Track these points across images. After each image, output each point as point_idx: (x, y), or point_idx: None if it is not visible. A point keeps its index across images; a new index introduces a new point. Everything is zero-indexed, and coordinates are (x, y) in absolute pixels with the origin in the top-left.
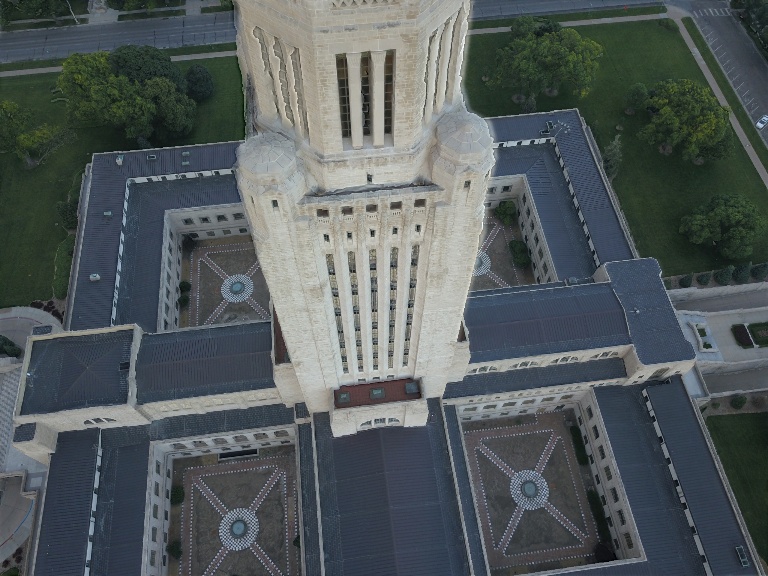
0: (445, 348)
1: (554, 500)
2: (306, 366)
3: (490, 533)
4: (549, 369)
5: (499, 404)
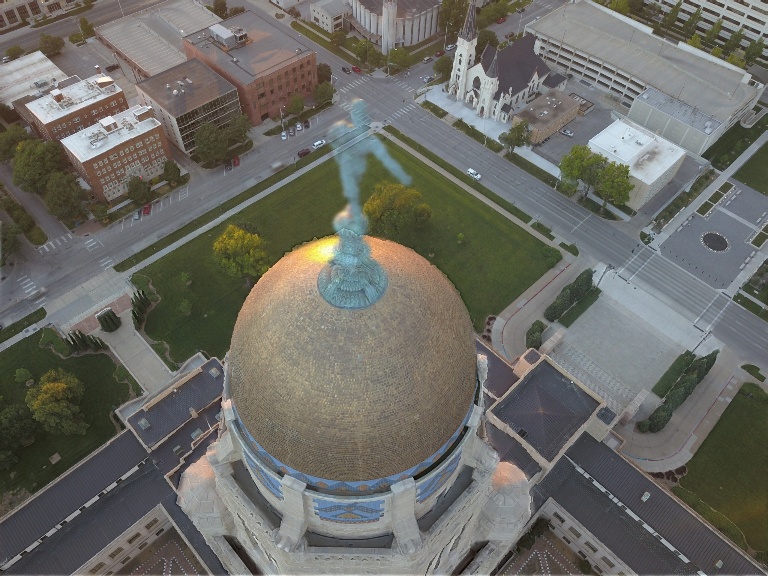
0: None
1: None
2: None
3: (183, 567)
4: None
5: None
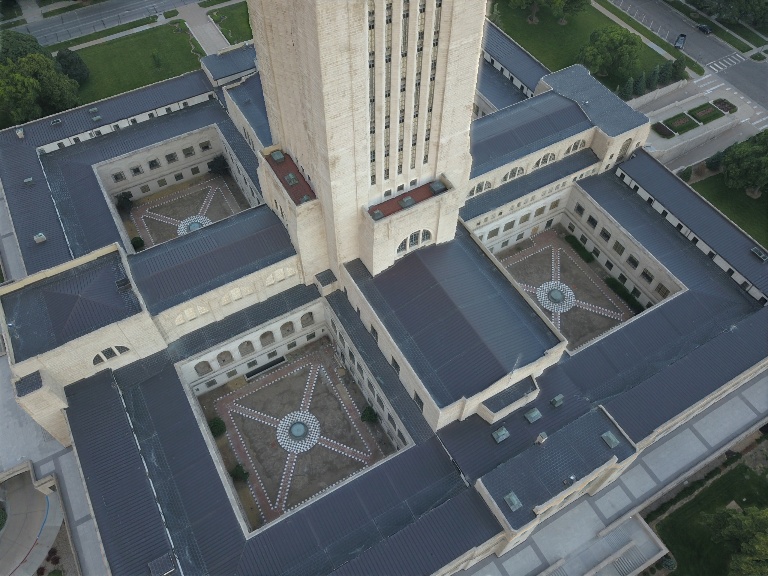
0: (463, 116)
1: (581, 297)
2: (341, 166)
3: None
4: (534, 174)
5: (501, 225)
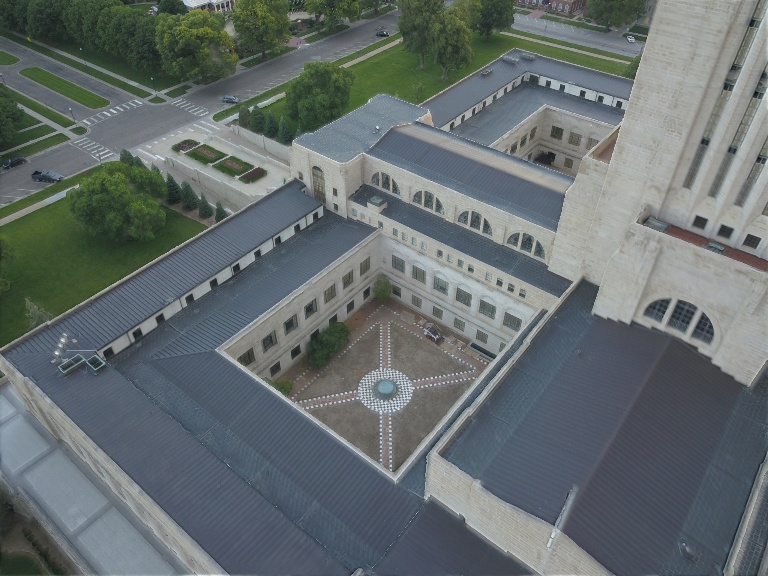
0: None
1: None
2: None
3: None
4: None
5: None
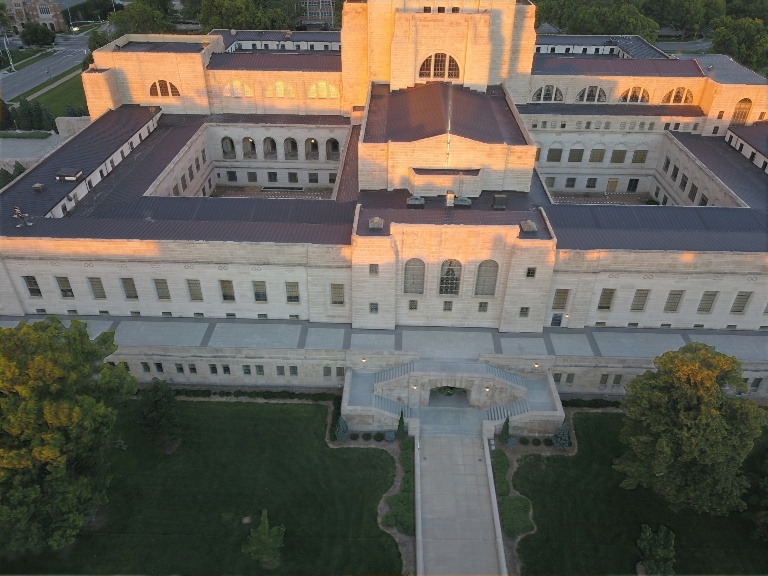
0: None
1: None
2: None
3: None
4: (618, 107)
5: (565, 147)
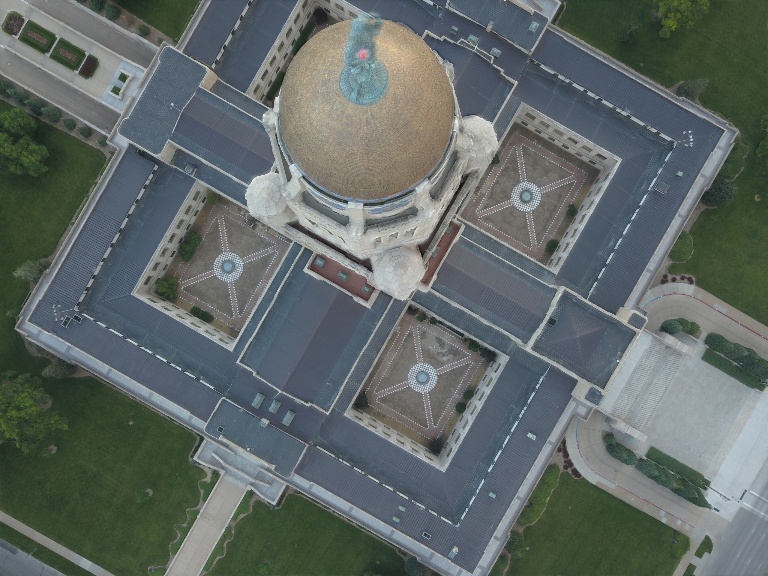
0: None
1: None
2: None
3: None
4: None
5: None
